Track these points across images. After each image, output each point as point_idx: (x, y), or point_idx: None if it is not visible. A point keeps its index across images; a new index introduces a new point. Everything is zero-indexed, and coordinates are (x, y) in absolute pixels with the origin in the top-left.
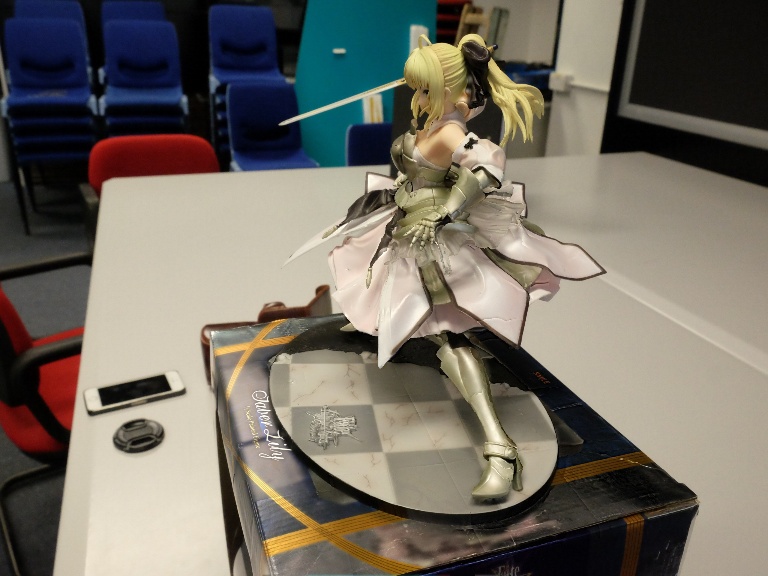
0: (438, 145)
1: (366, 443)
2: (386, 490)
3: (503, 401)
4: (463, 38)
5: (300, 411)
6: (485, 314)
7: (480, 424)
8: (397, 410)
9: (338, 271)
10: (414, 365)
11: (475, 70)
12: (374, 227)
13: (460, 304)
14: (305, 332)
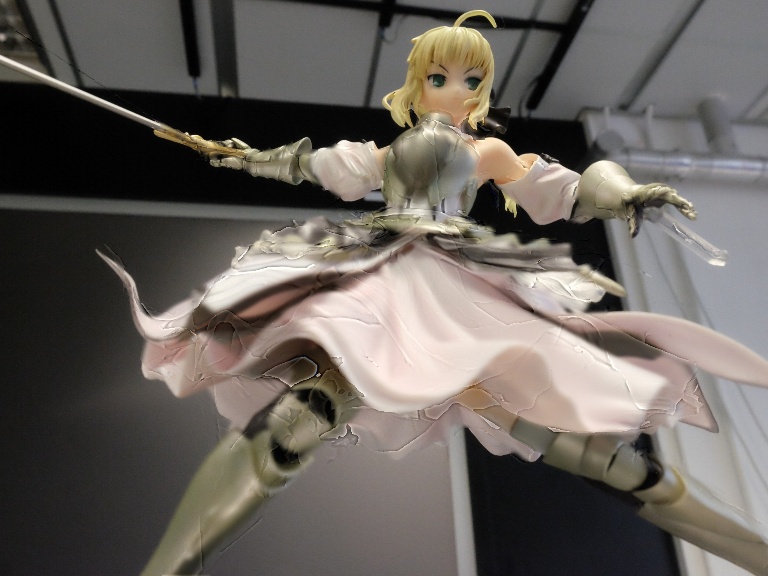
0: (489, 155)
1: None
2: None
3: None
4: None
5: None
6: None
7: None
8: None
9: (403, 325)
10: None
11: None
12: (375, 267)
13: None
14: None
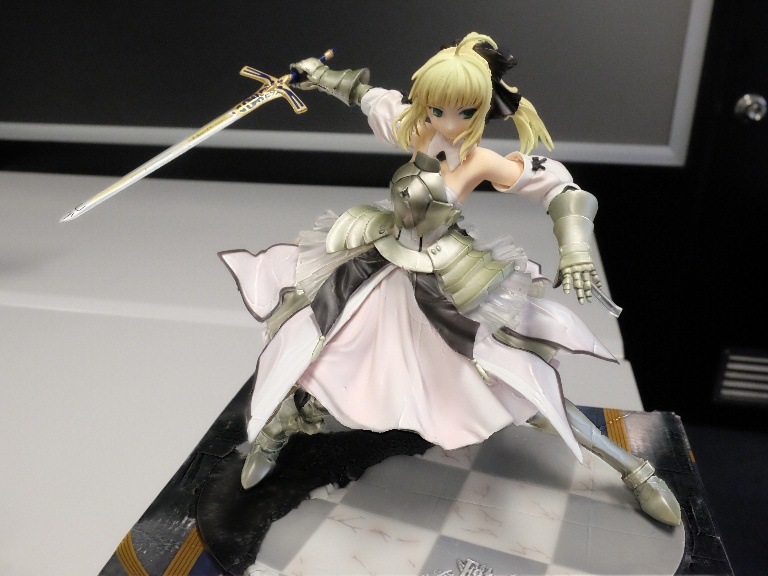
0: (476, 177)
1: (524, 571)
2: None
3: (497, 439)
4: None
5: None
6: (590, 346)
7: (528, 471)
8: (465, 518)
9: (337, 397)
10: (376, 466)
11: (496, 77)
12: (354, 315)
13: (573, 348)
14: (202, 525)
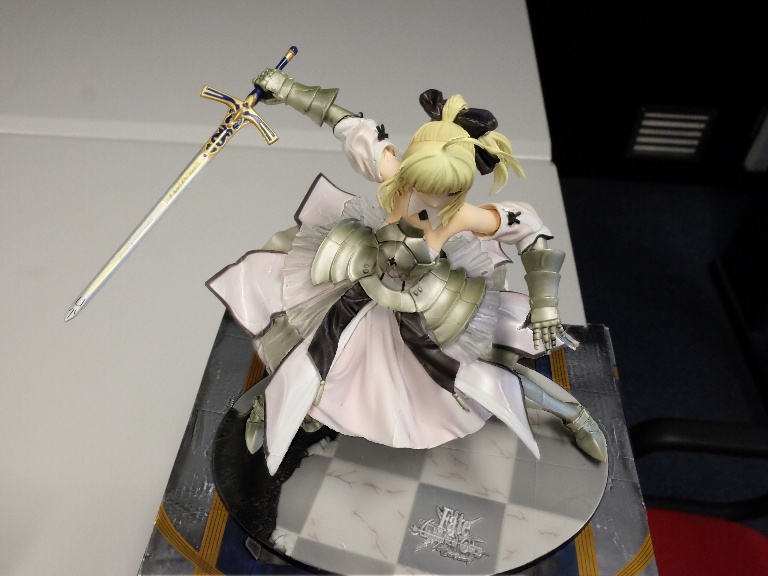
0: None
1: (488, 513)
2: (565, 523)
3: None
4: (453, 107)
5: (409, 557)
6: None
7: None
8: (439, 464)
9: (337, 417)
10: None
11: None
12: None
13: (533, 353)
14: (223, 494)
